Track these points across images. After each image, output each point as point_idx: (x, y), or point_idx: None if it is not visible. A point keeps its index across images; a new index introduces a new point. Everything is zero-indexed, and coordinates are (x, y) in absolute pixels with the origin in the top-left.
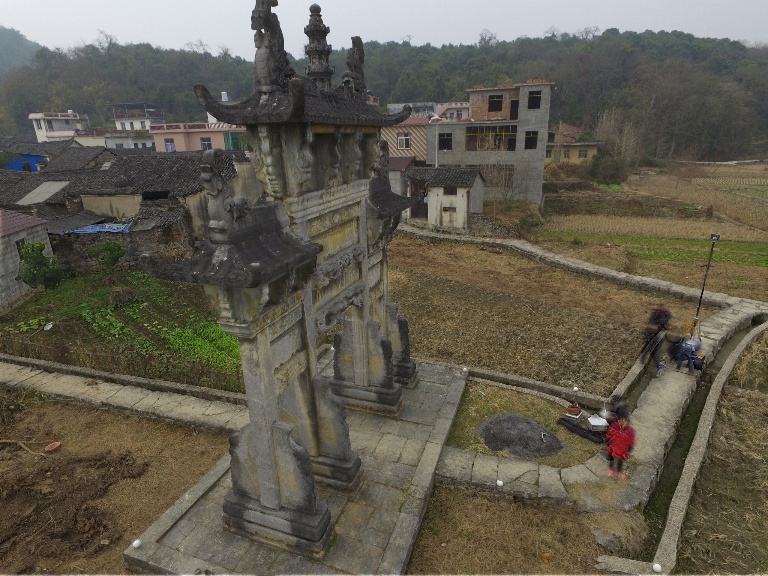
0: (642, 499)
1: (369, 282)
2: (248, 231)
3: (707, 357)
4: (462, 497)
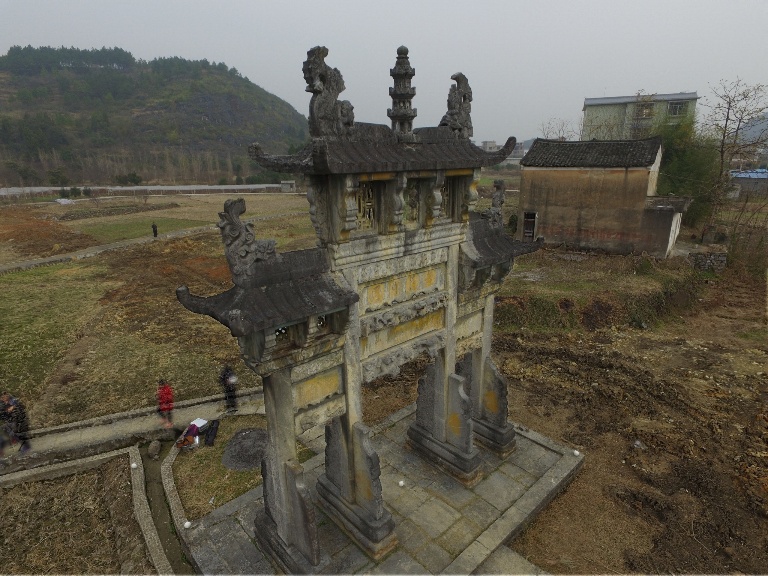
0: None
1: None
2: None
3: None
4: None
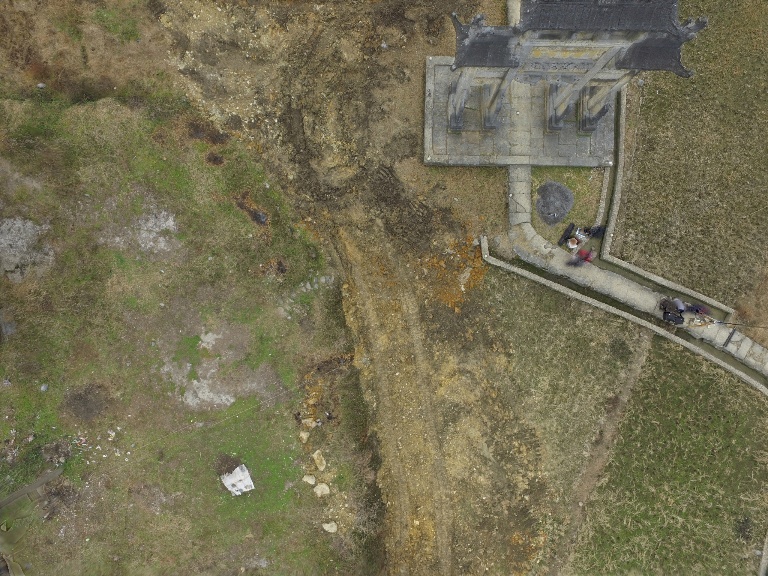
0: (521, 257)
1: (599, 76)
2: (483, 42)
3: (691, 331)
4: (503, 181)
